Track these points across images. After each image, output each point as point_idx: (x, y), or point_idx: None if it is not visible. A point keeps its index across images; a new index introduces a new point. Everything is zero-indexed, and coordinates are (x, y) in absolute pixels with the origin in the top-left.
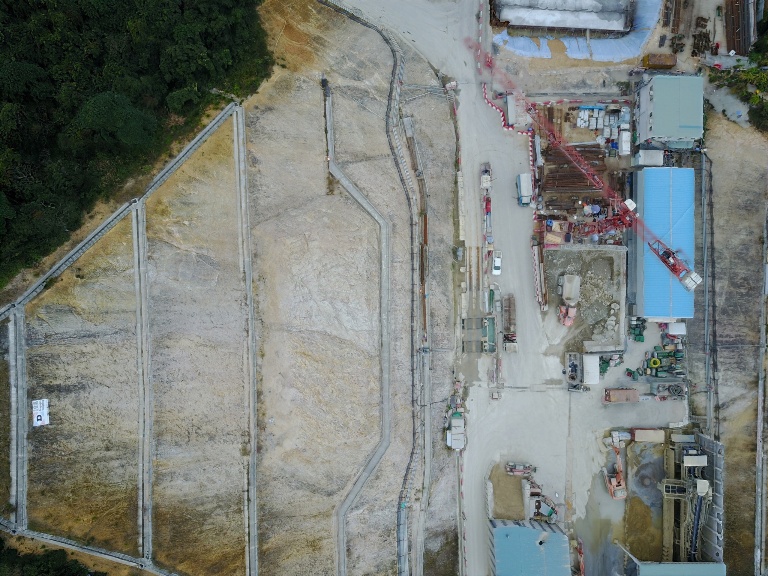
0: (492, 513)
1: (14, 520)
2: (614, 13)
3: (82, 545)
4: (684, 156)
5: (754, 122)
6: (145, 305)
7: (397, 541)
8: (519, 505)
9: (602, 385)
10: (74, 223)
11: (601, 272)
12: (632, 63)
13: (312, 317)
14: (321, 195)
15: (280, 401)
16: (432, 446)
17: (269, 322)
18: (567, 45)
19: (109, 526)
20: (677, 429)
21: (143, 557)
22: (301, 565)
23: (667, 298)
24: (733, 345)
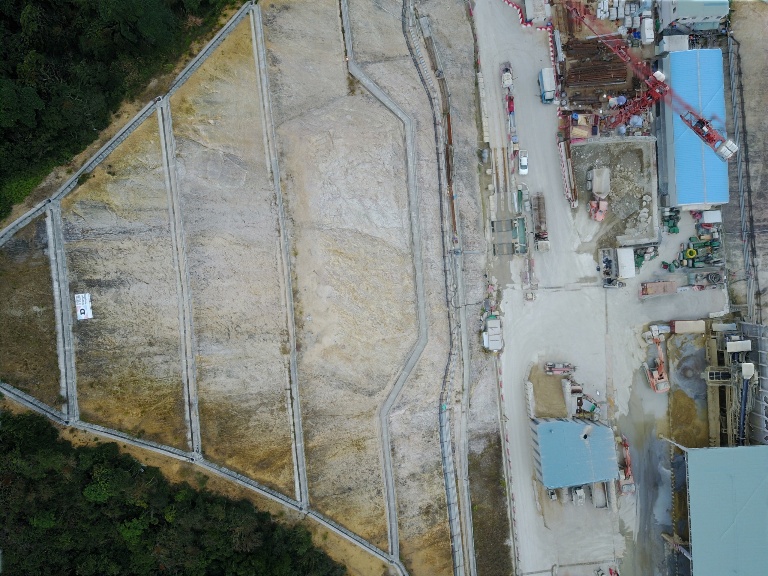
0: (534, 412)
1: (66, 412)
2: None
3: (133, 438)
4: (710, 40)
5: None
6: (177, 203)
7: (441, 442)
8: (561, 403)
9: (638, 280)
10: (101, 122)
11: (630, 165)
12: None
13: (342, 215)
14: (342, 96)
15: (316, 299)
16: (469, 348)
17: (300, 221)
18: None
19: (158, 420)
20: (718, 319)
21: (193, 451)
22: (348, 463)
23: (700, 184)
24: None
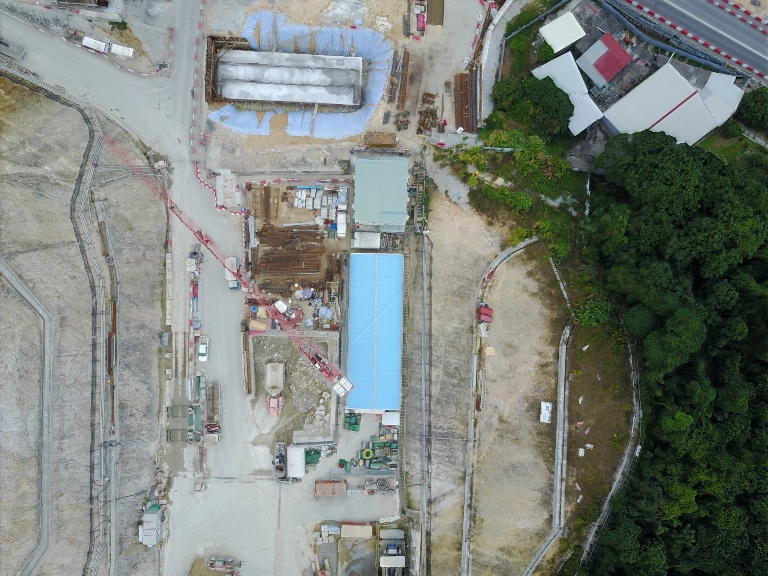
0: None
1: None
2: (343, 87)
3: None
4: (406, 238)
5: (474, 204)
6: None
7: None
8: None
9: (314, 476)
10: None
11: None
12: (355, 141)
13: None
14: None
15: None
16: (119, 543)
17: None
18: (290, 121)
19: None
20: (389, 524)
21: None
22: None
23: (371, 390)
24: (445, 438)
